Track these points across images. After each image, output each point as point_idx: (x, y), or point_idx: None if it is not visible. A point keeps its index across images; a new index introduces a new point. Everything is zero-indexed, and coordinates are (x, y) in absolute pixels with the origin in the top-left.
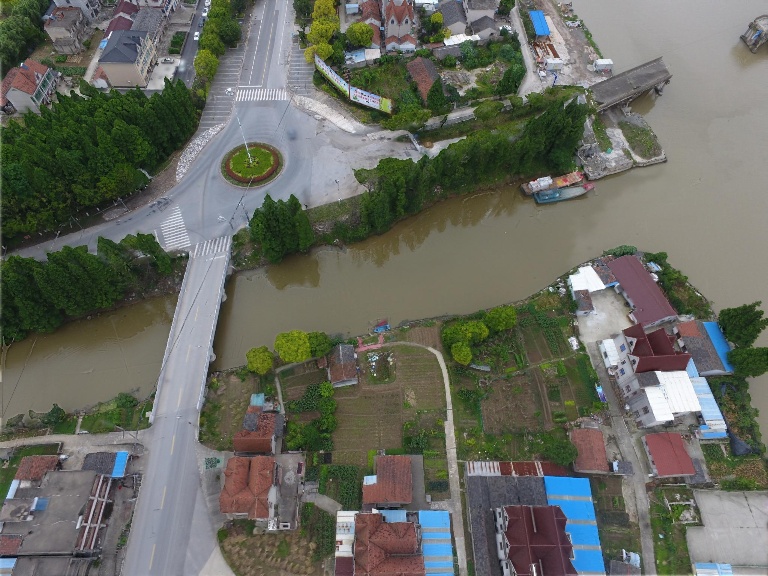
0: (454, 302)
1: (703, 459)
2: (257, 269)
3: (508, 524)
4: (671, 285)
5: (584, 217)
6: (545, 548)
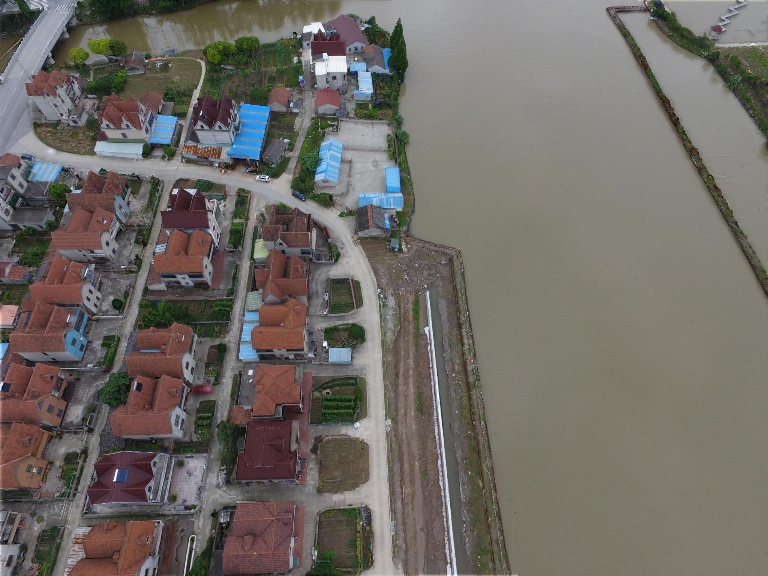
0: None
1: (353, 108)
2: (94, 24)
3: (198, 103)
4: (375, 36)
5: (336, 7)
6: (214, 110)
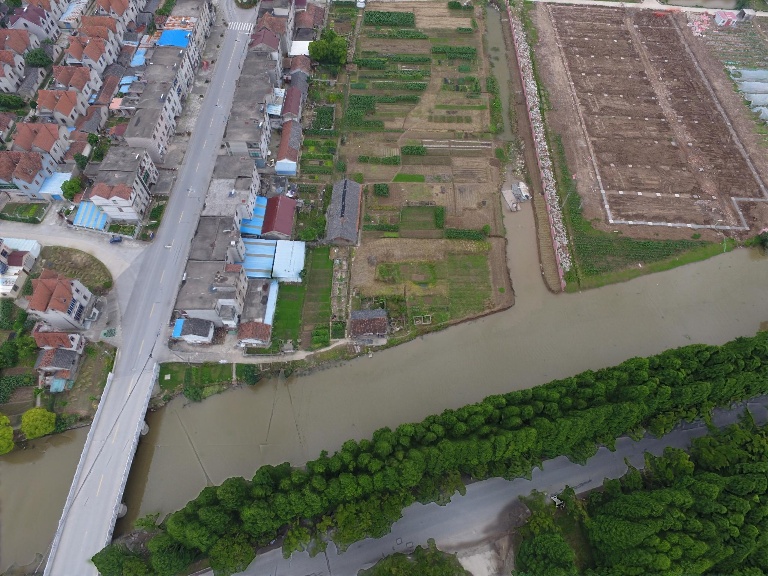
0: None
1: None
2: (22, 574)
3: None
4: None
5: None
6: None
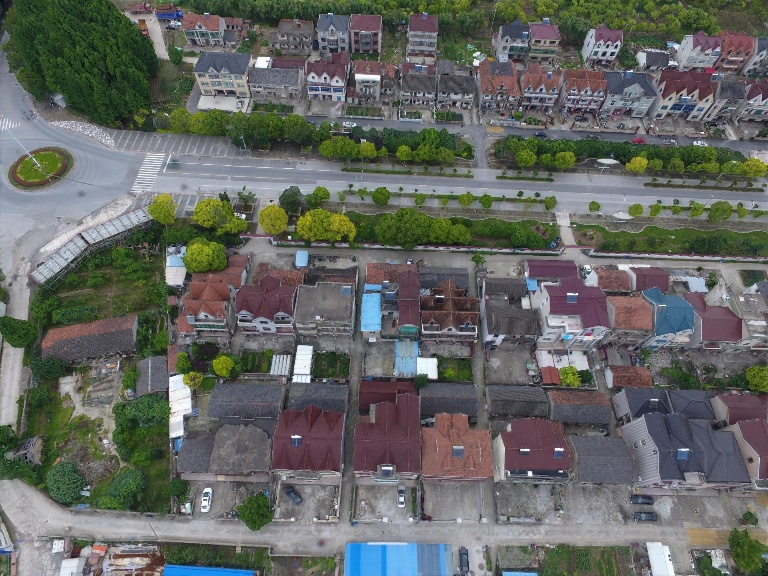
0: None
1: None
2: None
3: None
4: None
5: None
6: None
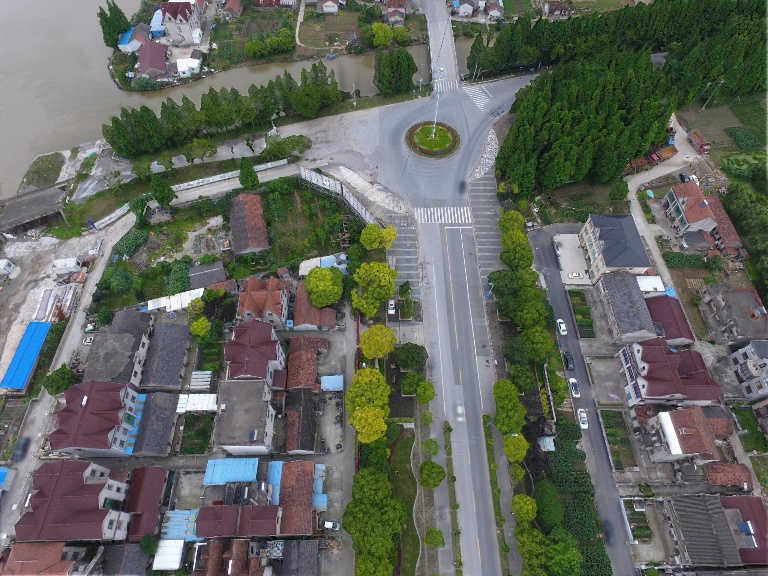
0: (281, 75)
1: None
2: None
3: None
4: None
5: None
6: None
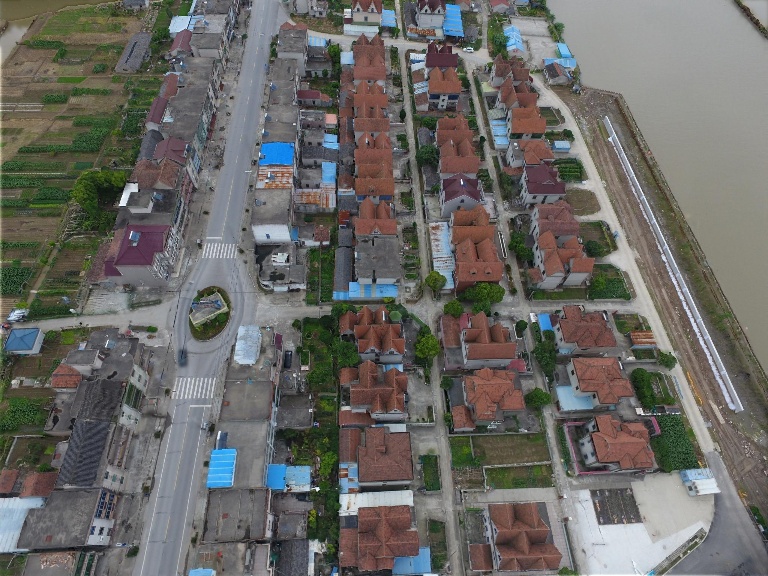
0: None
1: (517, 10)
2: None
3: None
4: None
5: None
6: None
